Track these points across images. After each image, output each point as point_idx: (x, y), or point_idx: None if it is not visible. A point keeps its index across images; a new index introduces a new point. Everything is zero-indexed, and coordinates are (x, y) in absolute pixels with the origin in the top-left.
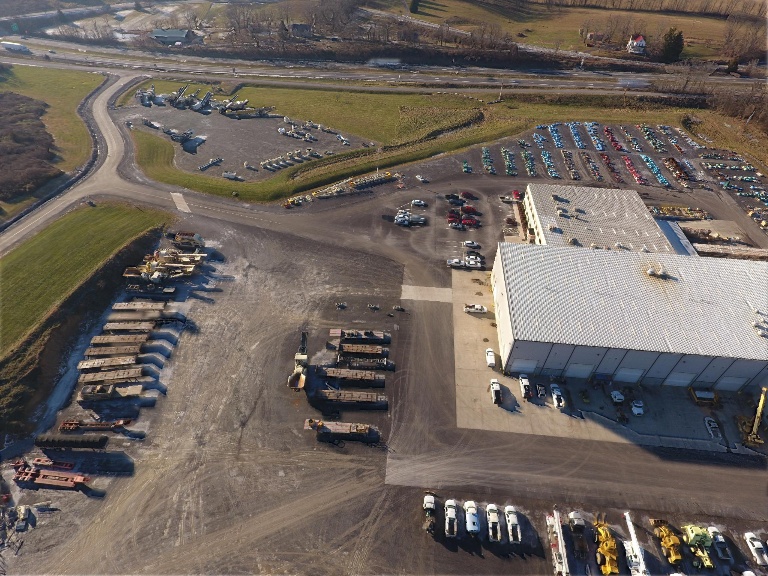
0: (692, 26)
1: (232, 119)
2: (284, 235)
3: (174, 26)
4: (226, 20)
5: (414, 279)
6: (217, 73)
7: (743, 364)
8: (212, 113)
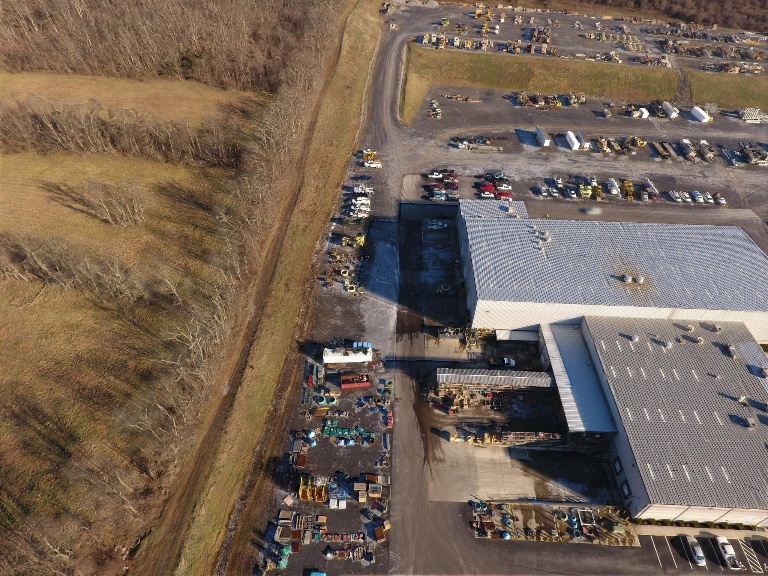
0: None
1: None
2: None
3: None
4: None
5: None
6: None
7: None
8: None
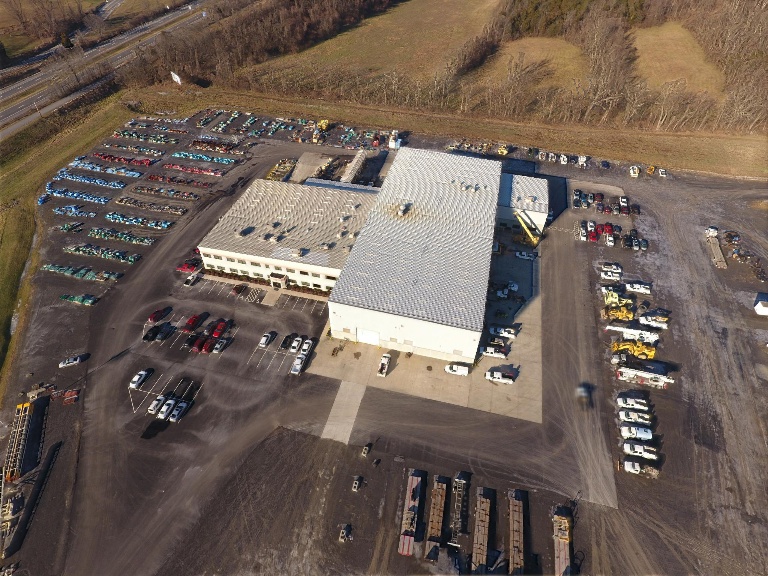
0: None
1: None
2: None
3: None
4: None
5: (313, 420)
6: None
7: None
8: None
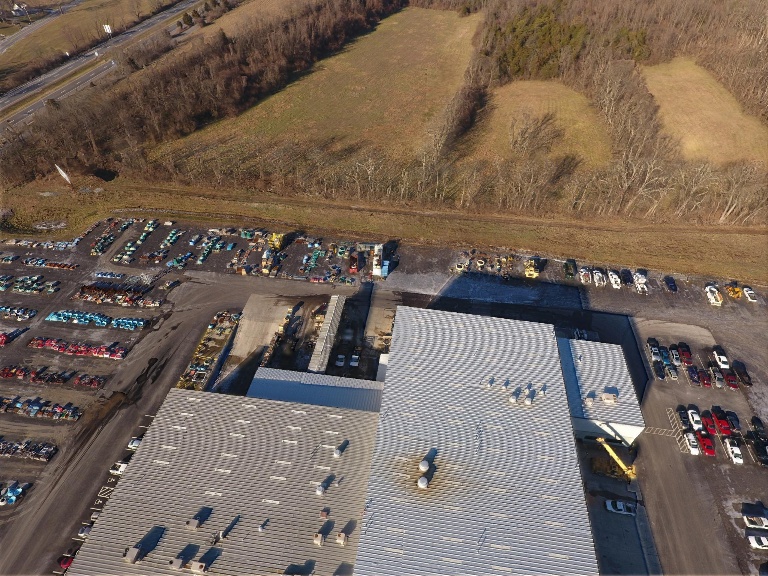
0: None
1: None
2: None
3: None
4: None
5: None
6: None
7: None
8: None
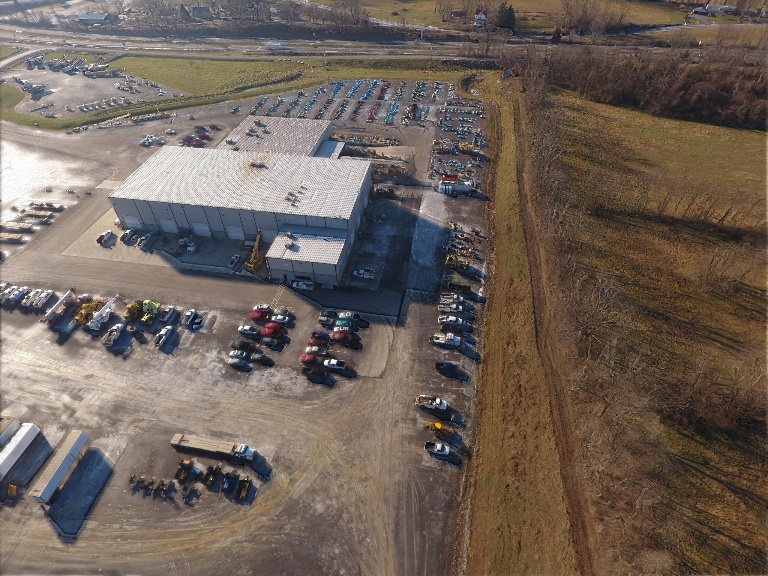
0: (539, 1)
1: (89, 78)
2: (49, 150)
3: (105, 12)
4: (150, 6)
5: (117, 177)
6: (112, 47)
7: (261, 216)
8: (77, 74)
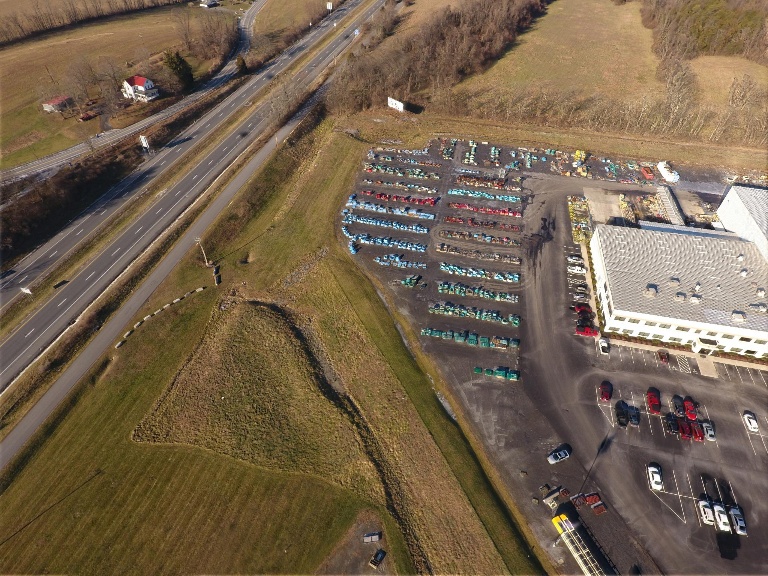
0: (142, 41)
1: None
2: None
3: None
4: None
5: None
6: None
7: None
8: None
